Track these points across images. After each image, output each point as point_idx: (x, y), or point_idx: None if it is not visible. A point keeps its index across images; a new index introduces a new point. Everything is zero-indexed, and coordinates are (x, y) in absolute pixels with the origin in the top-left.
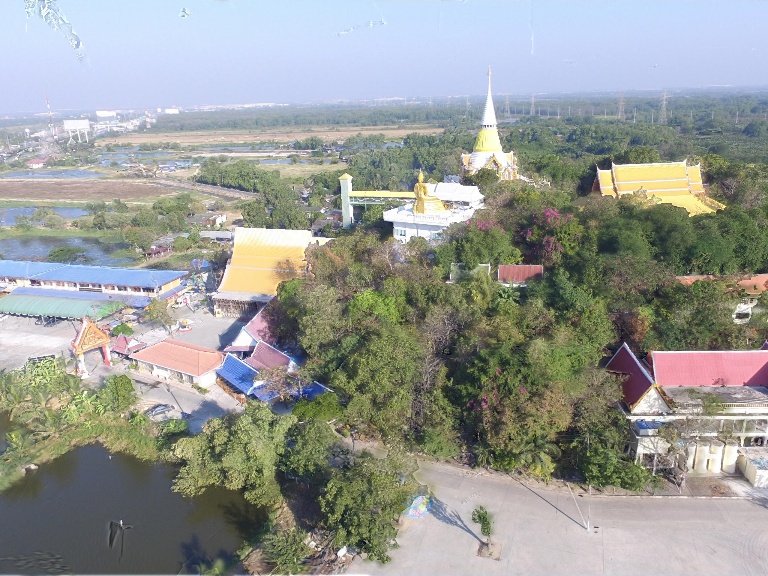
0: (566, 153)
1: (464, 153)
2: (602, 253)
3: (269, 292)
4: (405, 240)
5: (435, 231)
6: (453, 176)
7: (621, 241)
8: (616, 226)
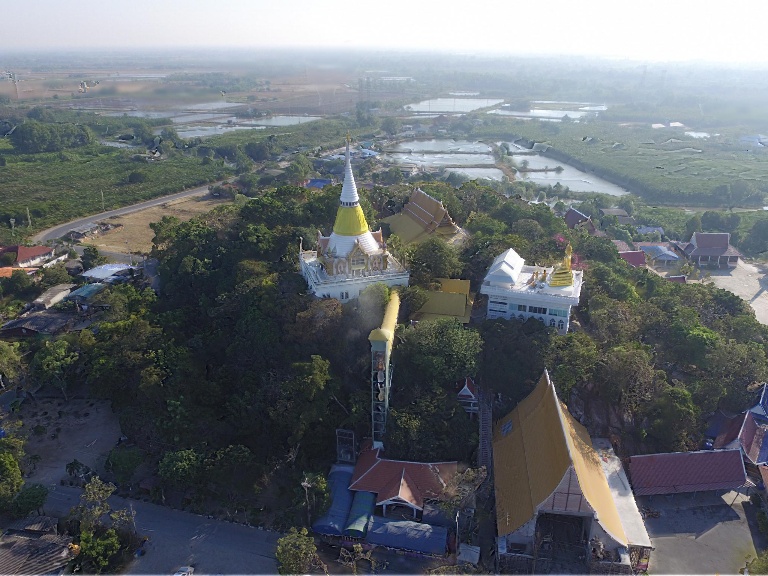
0: None
1: None
2: None
3: (605, 479)
4: None
5: None
6: None
7: None
8: None
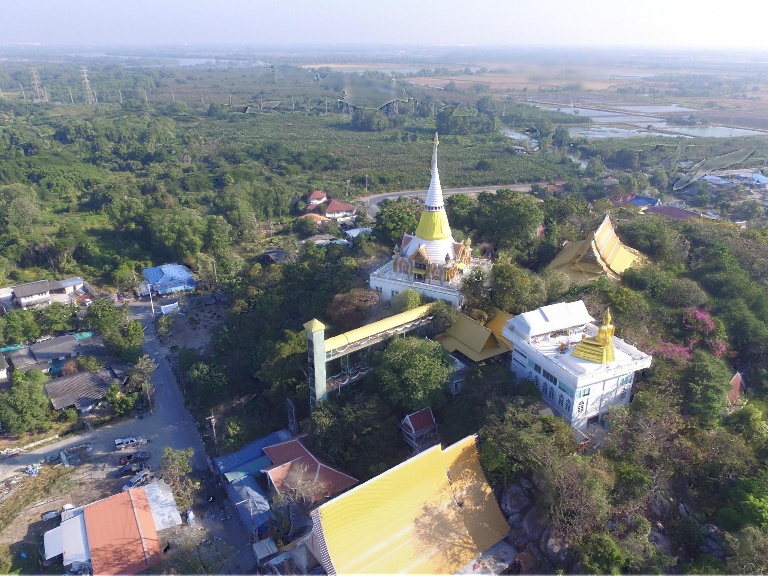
0: (103, 163)
1: (28, 190)
2: (728, 337)
3: None
4: (588, 400)
5: (625, 376)
6: (376, 272)
7: (752, 323)
8: (731, 309)
